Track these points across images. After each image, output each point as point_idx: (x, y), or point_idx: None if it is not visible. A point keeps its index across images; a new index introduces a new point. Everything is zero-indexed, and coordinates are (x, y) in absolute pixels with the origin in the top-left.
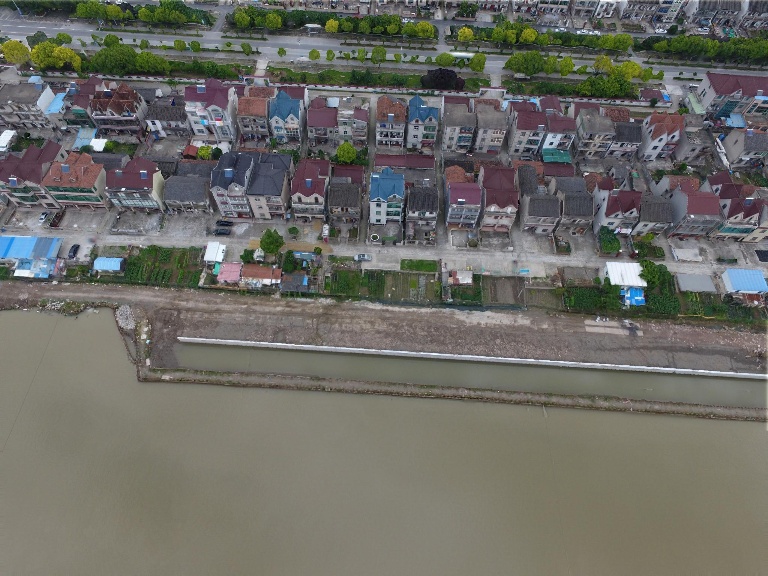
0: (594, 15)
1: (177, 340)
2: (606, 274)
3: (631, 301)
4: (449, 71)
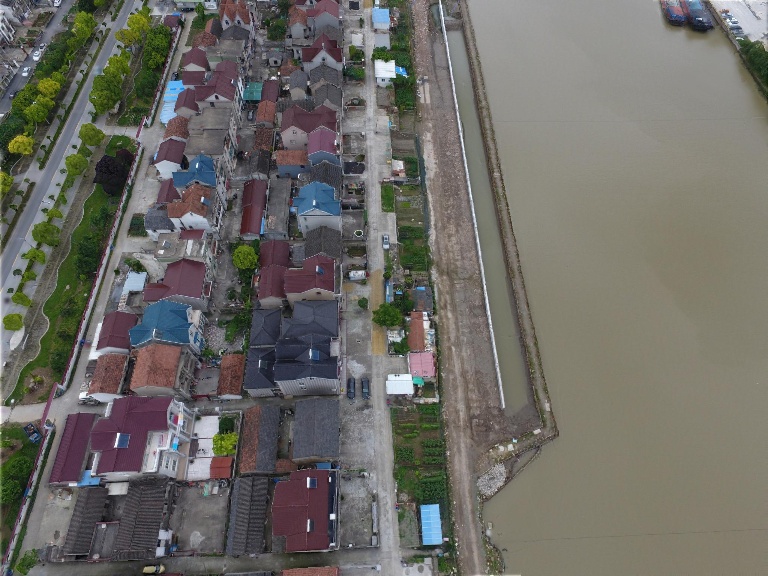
0: (8, 41)
1: (502, 413)
2: (384, 81)
3: (404, 74)
4: (105, 159)
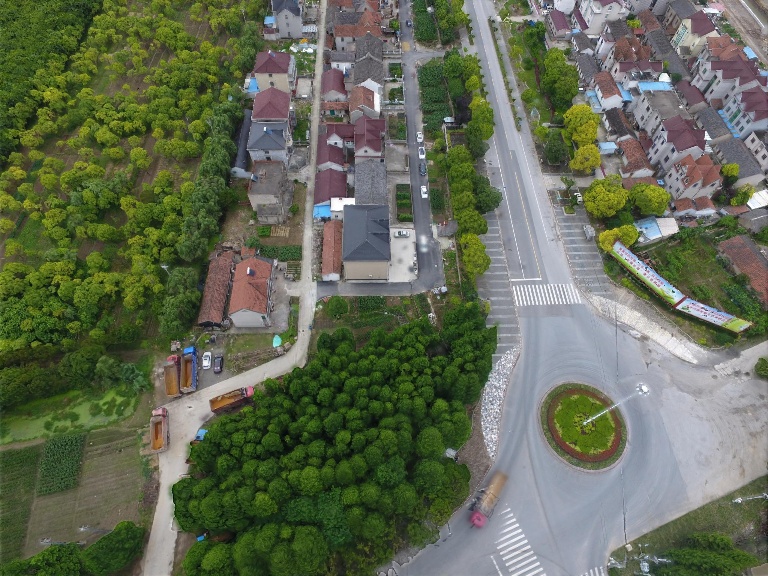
0: None
1: (762, 33)
2: None
3: None
4: None
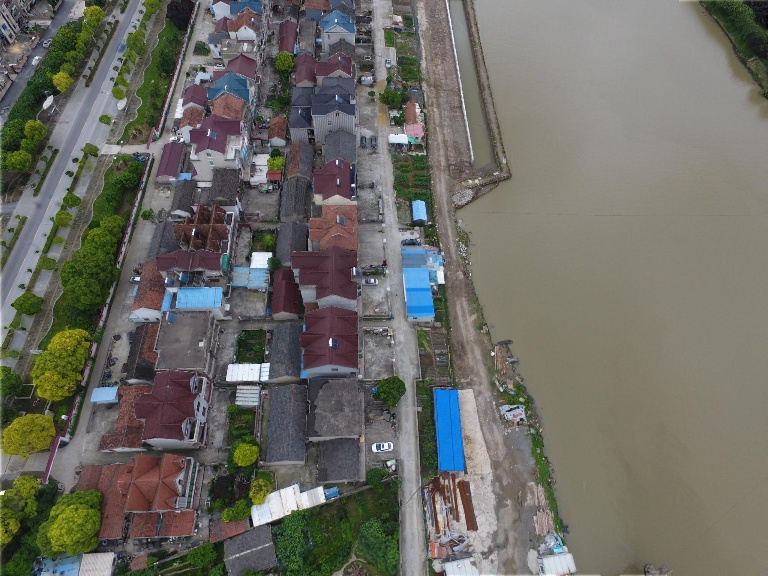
0: None
1: (472, 166)
2: None
3: None
4: (174, 2)
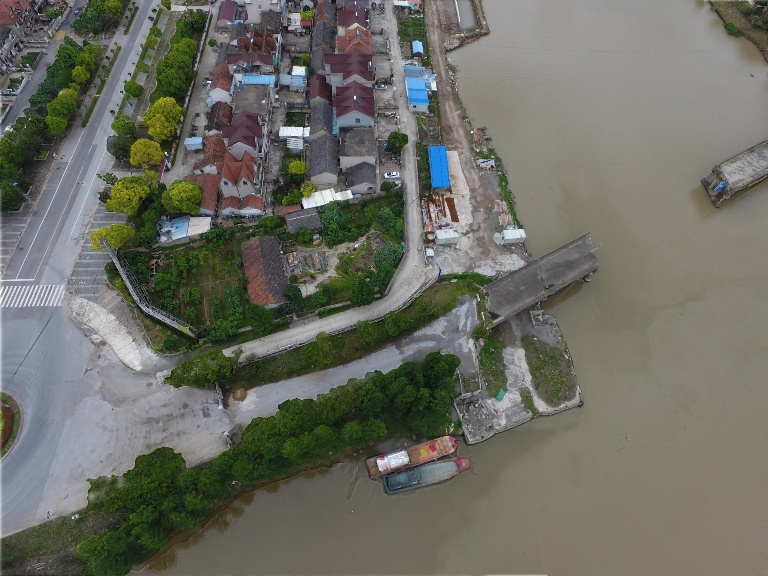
0: None
1: (459, 27)
2: None
3: None
4: None
